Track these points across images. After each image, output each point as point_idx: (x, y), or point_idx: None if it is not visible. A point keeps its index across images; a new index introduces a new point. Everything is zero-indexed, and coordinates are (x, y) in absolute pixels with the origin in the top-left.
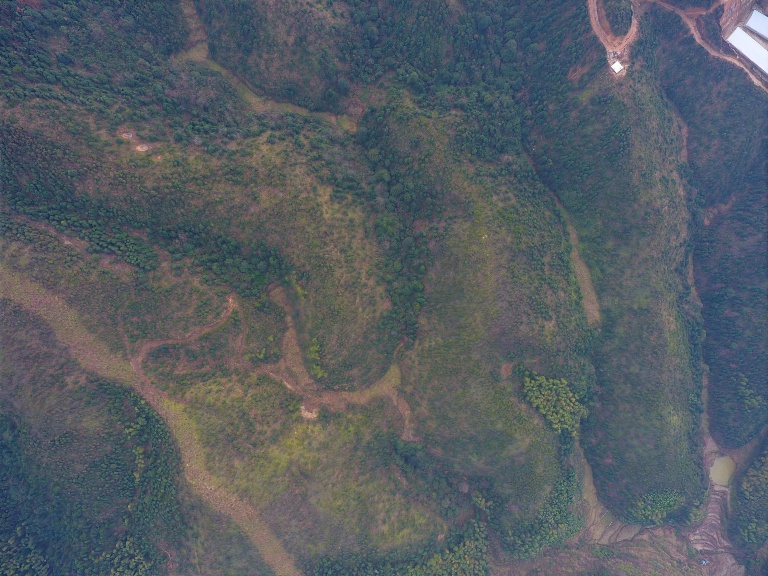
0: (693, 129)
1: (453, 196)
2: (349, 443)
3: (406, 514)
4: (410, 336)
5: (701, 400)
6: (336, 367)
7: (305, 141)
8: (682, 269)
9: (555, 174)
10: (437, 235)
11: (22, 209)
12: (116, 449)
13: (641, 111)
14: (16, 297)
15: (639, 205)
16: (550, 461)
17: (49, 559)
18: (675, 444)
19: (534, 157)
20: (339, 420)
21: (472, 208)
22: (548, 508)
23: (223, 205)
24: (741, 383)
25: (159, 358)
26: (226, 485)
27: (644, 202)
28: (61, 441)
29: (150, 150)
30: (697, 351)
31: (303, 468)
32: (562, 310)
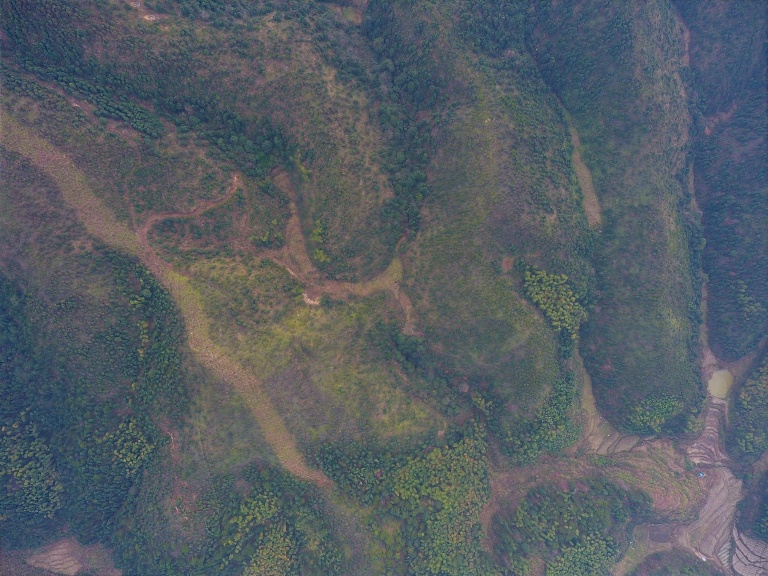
0: (695, 33)
1: (456, 83)
2: (351, 327)
3: (406, 408)
4: (412, 228)
5: (700, 311)
6: (339, 253)
7: (311, 23)
8: (683, 176)
9: (558, 72)
10: (440, 121)
11: (31, 68)
12: (121, 321)
13: (644, 2)
14: (25, 151)
15: (641, 100)
16: (550, 360)
17: (53, 447)
18: (674, 346)
19: (537, 57)
20: (341, 307)
21: (475, 94)
22: (547, 408)
23: (229, 77)
24: (740, 291)
25: (164, 232)
26: (229, 354)
27: (646, 97)
28: (67, 305)
29: (158, 20)
30: (697, 259)
31: (305, 344)
32: (563, 206)
